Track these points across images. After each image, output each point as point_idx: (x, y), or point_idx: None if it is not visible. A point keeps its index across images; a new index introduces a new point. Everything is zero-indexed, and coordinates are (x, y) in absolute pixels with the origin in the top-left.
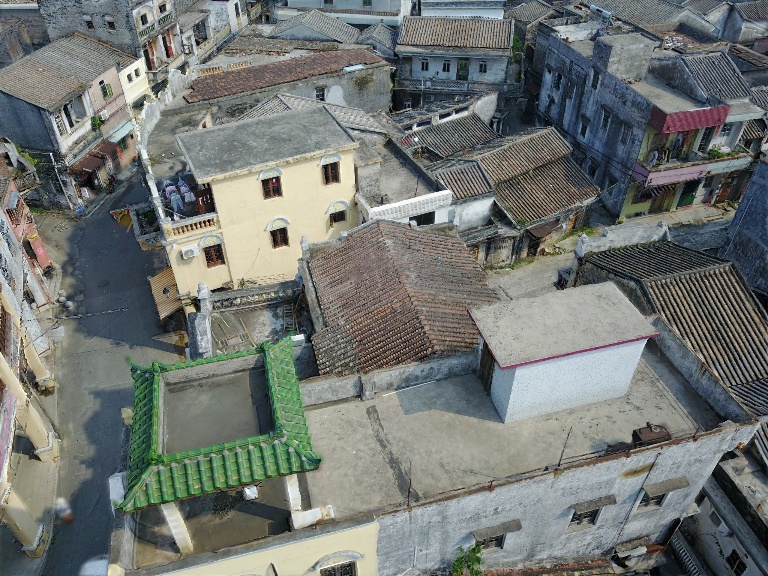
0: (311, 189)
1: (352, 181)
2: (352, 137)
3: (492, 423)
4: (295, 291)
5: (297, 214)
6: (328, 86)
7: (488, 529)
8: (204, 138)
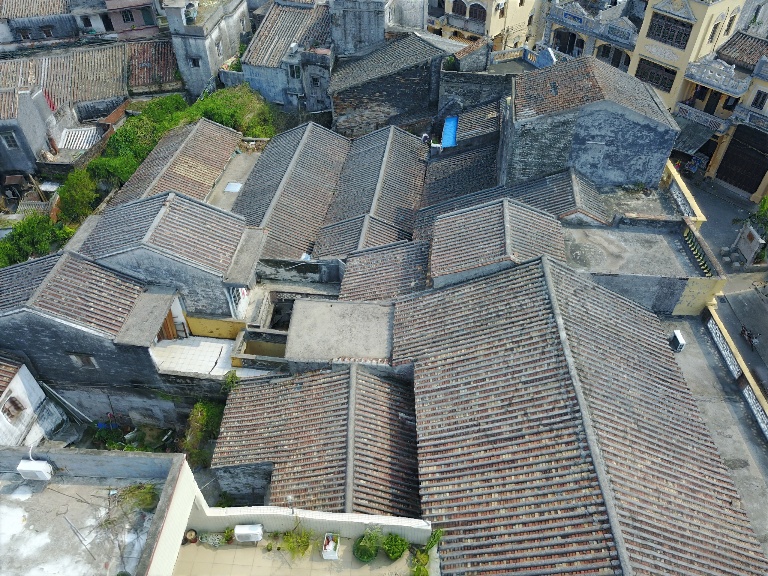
0: None
1: None
2: None
3: None
4: (581, 0)
5: None
6: None
7: (761, 3)
8: None
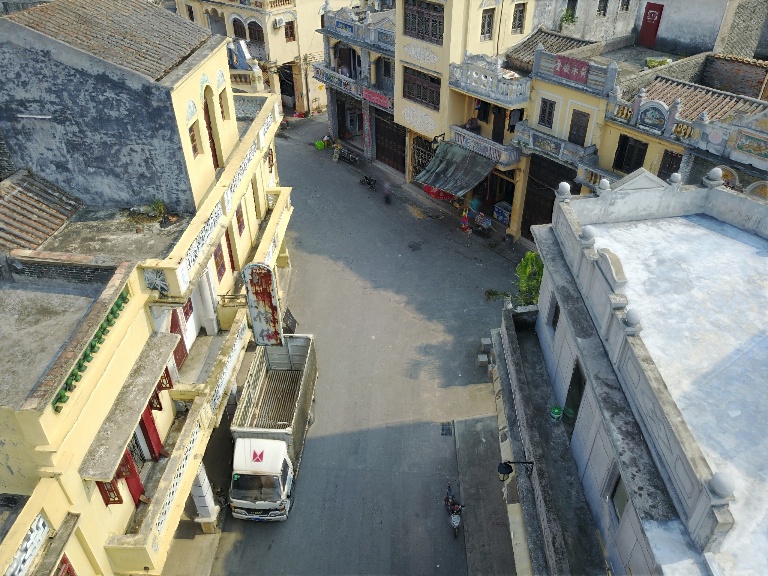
0: None
1: None
2: None
3: None
4: None
5: (335, 3)
6: None
7: None
8: None
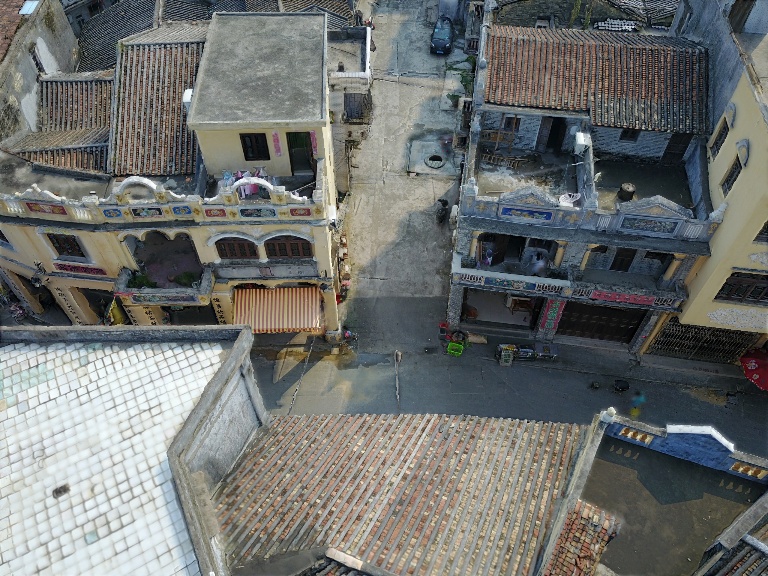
0: None
1: None
2: (312, 13)
3: (766, 38)
4: None
5: None
6: (34, 43)
7: None
8: (215, 104)
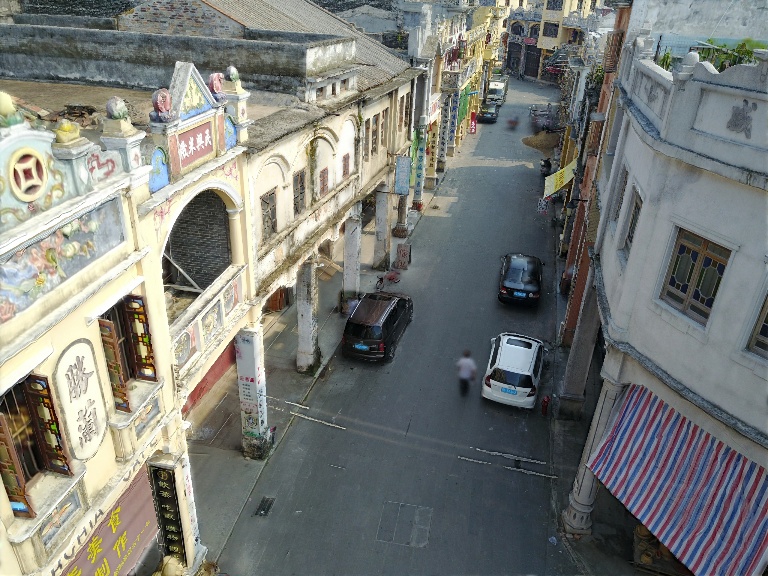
0: (516, 7)
1: (525, 8)
2: None
3: None
4: None
5: None
6: None
7: None
8: None
